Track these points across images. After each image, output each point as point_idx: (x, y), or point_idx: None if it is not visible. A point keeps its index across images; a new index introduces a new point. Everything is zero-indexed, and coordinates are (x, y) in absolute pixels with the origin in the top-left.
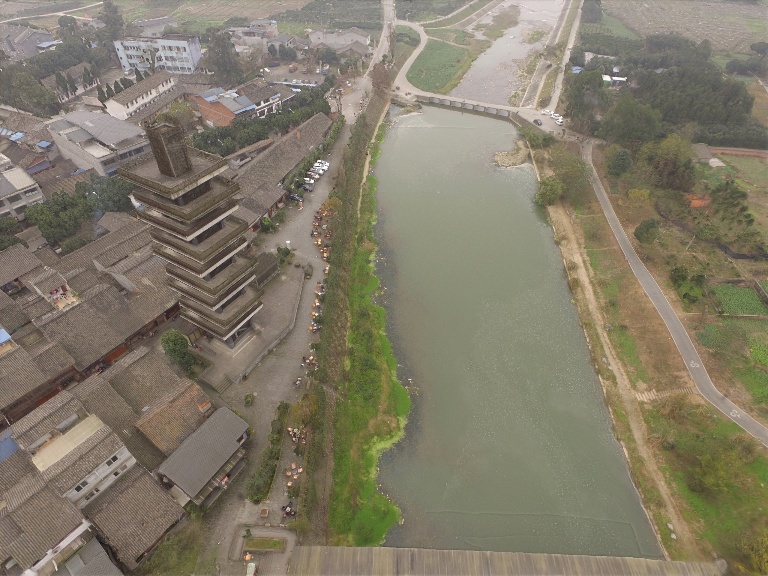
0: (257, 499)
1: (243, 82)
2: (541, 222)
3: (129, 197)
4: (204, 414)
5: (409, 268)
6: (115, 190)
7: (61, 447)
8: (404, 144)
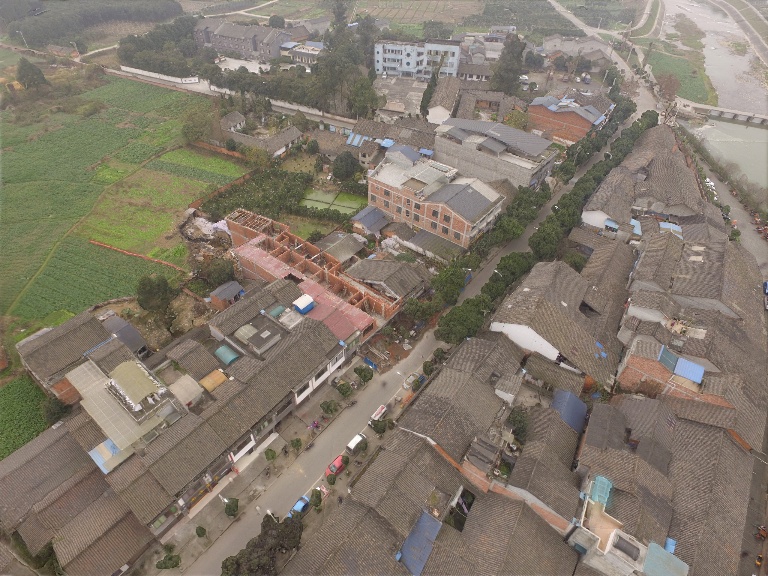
0: None
1: (517, 89)
2: None
3: (584, 212)
4: None
5: None
6: None
7: None
8: (737, 159)
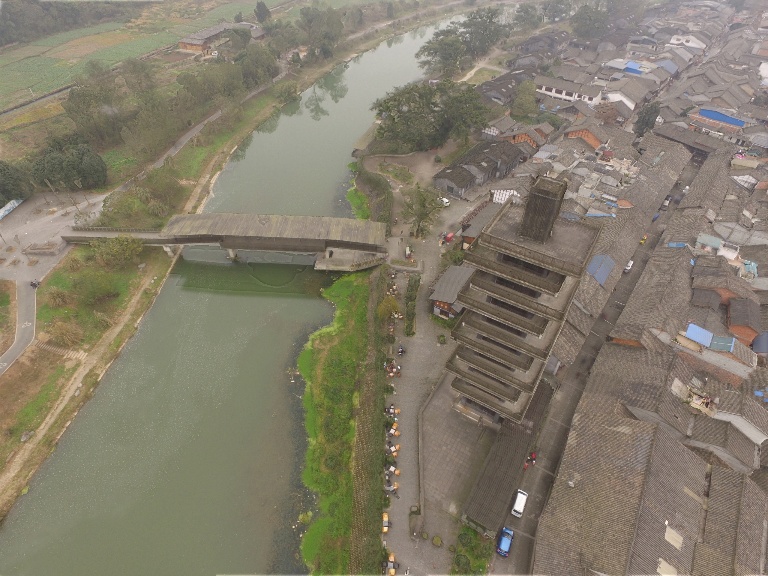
0: None
1: None
2: None
3: None
4: None
5: None
6: None
7: None
8: None
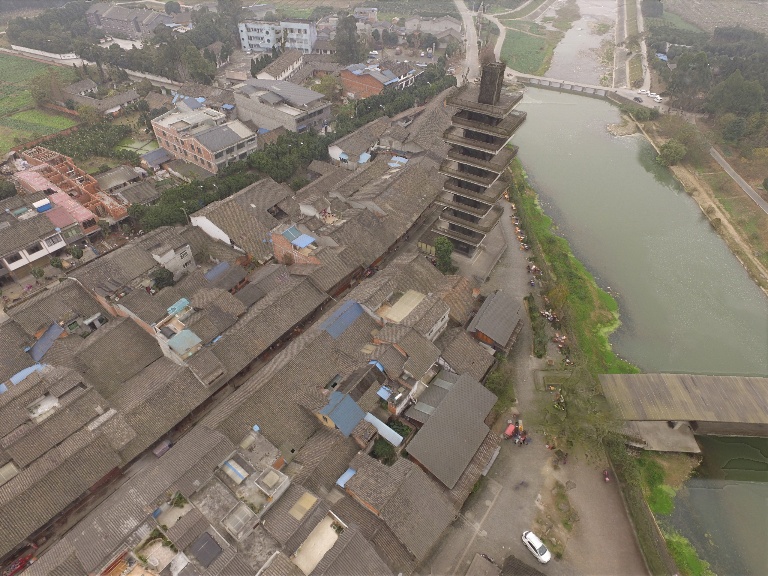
0: (541, 354)
1: (360, 62)
2: (661, 181)
3: (328, 148)
4: (476, 299)
5: (572, 210)
6: (318, 142)
7: (402, 308)
8: None
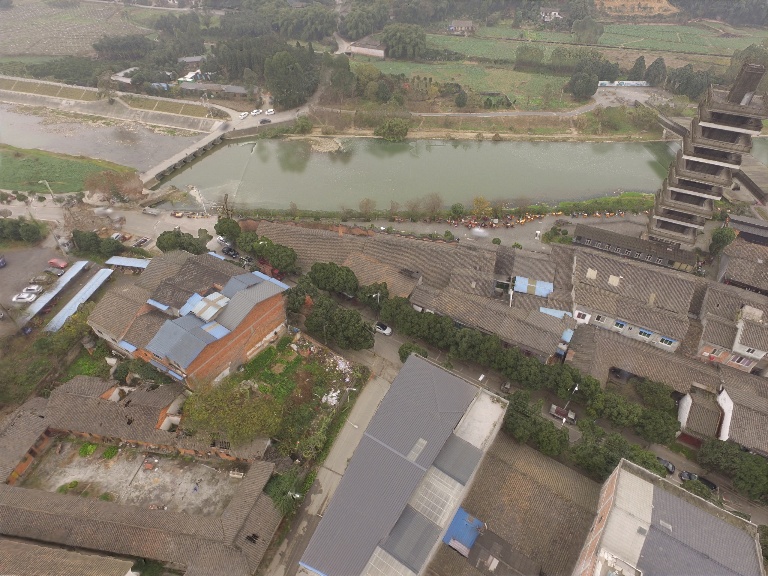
0: None
1: None
2: None
3: None
4: None
5: (509, 193)
6: (557, 365)
7: None
8: (287, 197)
